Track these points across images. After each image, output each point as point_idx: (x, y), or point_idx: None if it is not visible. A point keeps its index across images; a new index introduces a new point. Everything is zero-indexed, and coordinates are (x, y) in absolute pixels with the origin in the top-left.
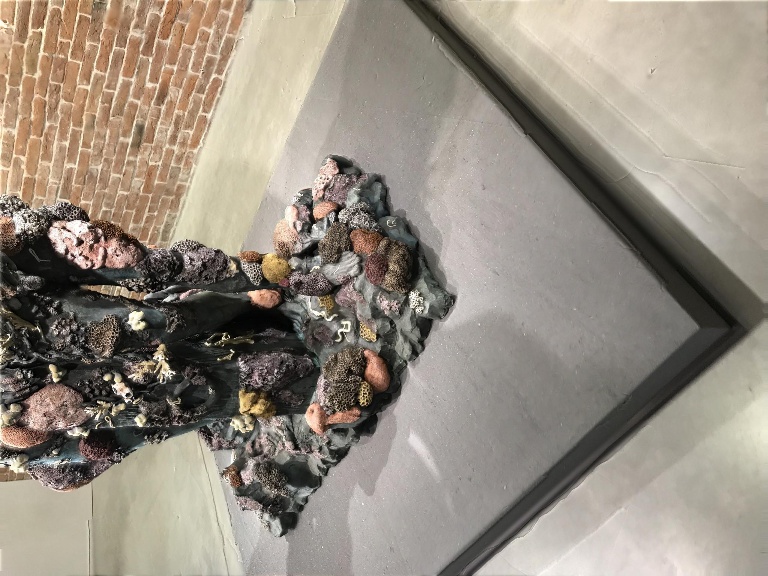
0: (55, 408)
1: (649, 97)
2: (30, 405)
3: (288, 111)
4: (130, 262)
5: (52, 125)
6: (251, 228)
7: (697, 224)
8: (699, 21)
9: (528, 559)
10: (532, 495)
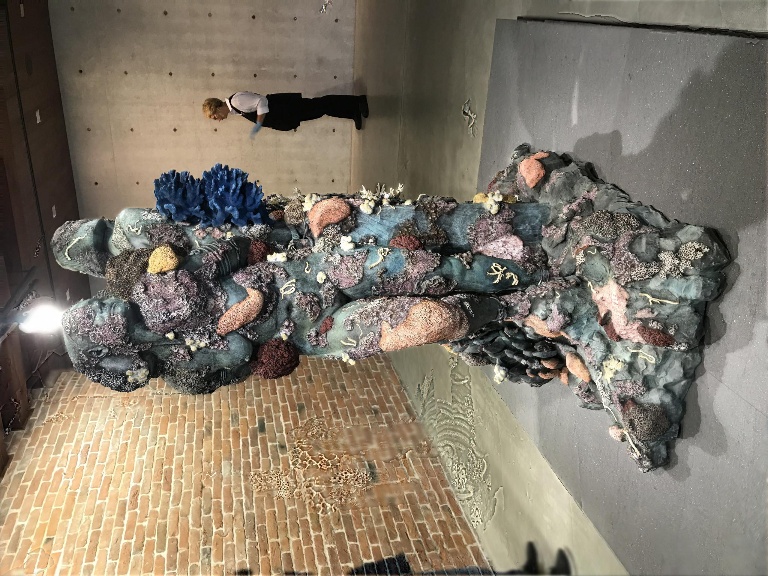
0: None
1: None
2: None
3: (538, 486)
4: None
5: None
6: (563, 480)
7: None
8: None
9: (628, 5)
10: None
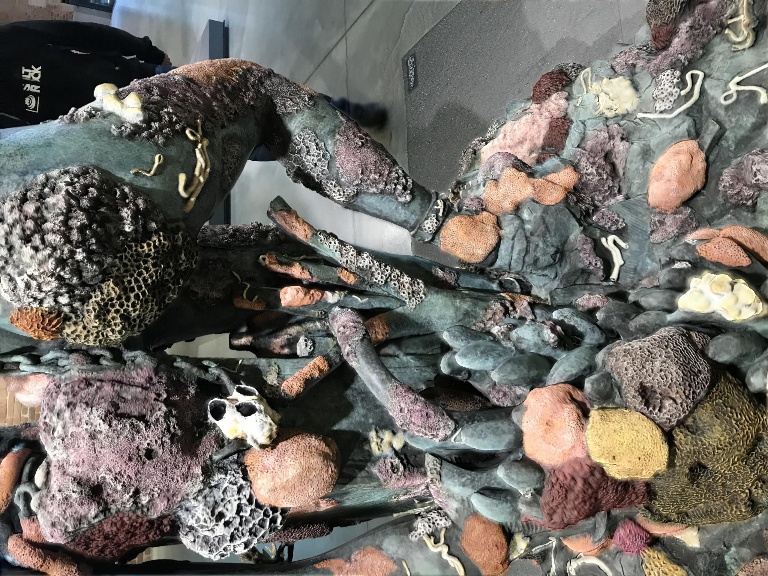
0: None
1: None
2: None
3: None
4: None
5: None
6: None
7: None
8: None
9: None
10: None
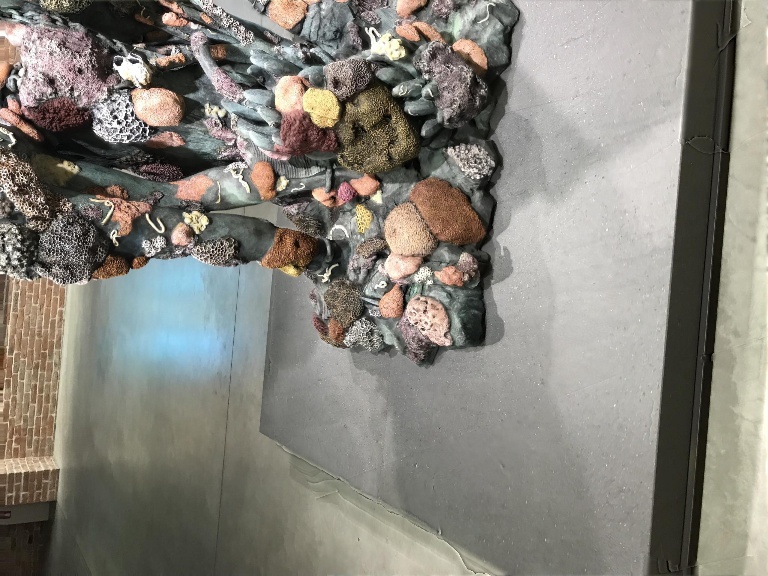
0: None
1: (353, 523)
2: None
3: None
4: None
5: None
6: (683, 5)
7: (292, 469)
8: (352, 573)
9: None
10: None
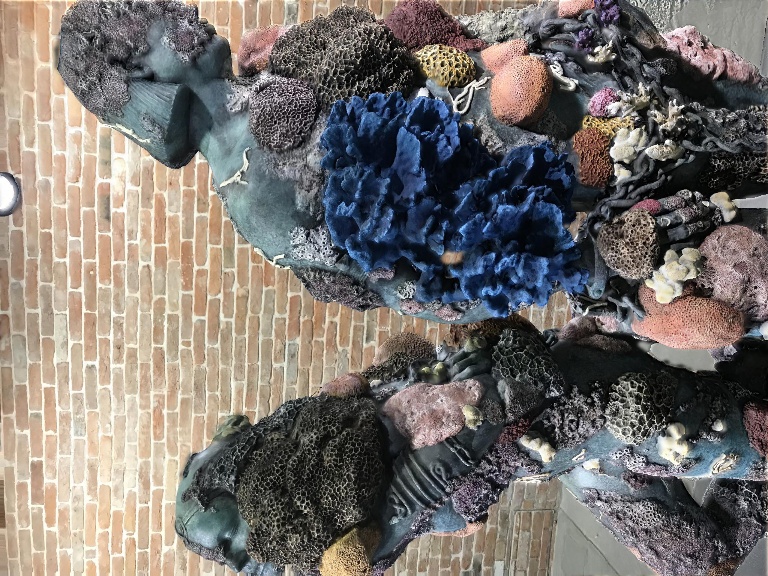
0: (746, 257)
1: None
2: (706, 257)
3: None
4: (753, 73)
5: (432, 329)
6: None
7: None
8: None
9: None
10: None
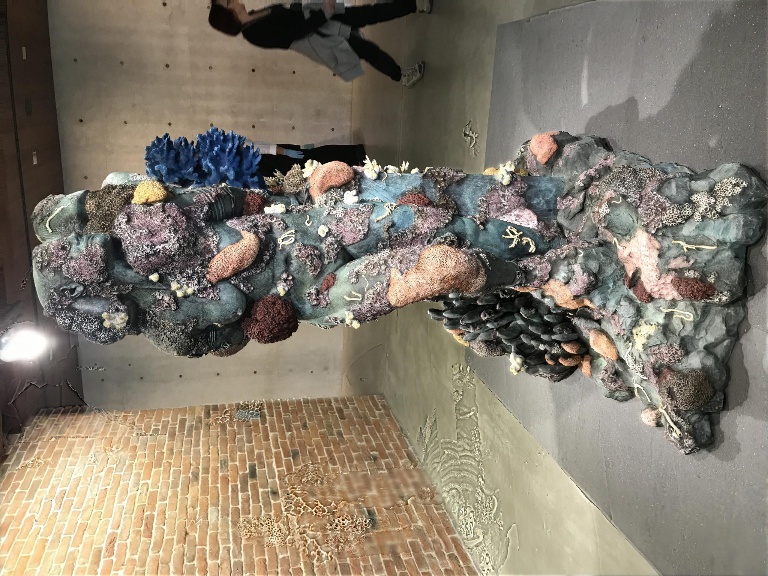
0: None
1: None
2: None
3: (556, 514)
4: None
5: None
6: (587, 492)
7: None
8: None
9: None
10: (558, 7)
